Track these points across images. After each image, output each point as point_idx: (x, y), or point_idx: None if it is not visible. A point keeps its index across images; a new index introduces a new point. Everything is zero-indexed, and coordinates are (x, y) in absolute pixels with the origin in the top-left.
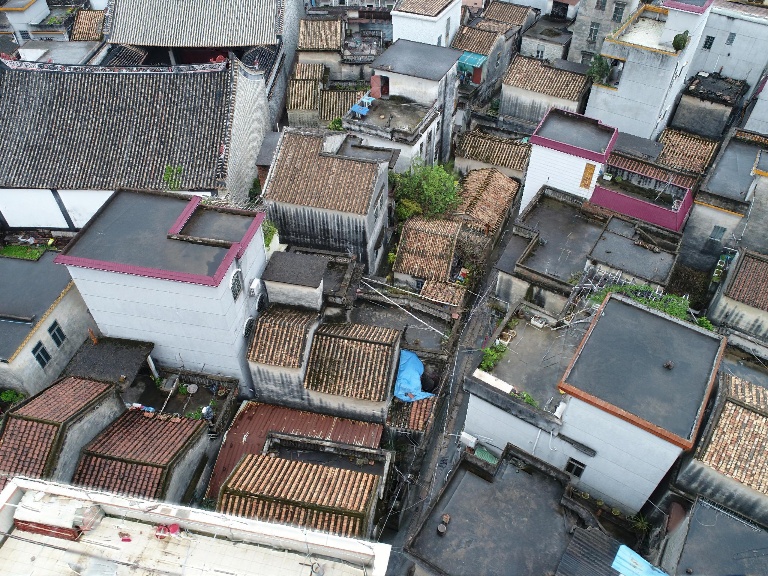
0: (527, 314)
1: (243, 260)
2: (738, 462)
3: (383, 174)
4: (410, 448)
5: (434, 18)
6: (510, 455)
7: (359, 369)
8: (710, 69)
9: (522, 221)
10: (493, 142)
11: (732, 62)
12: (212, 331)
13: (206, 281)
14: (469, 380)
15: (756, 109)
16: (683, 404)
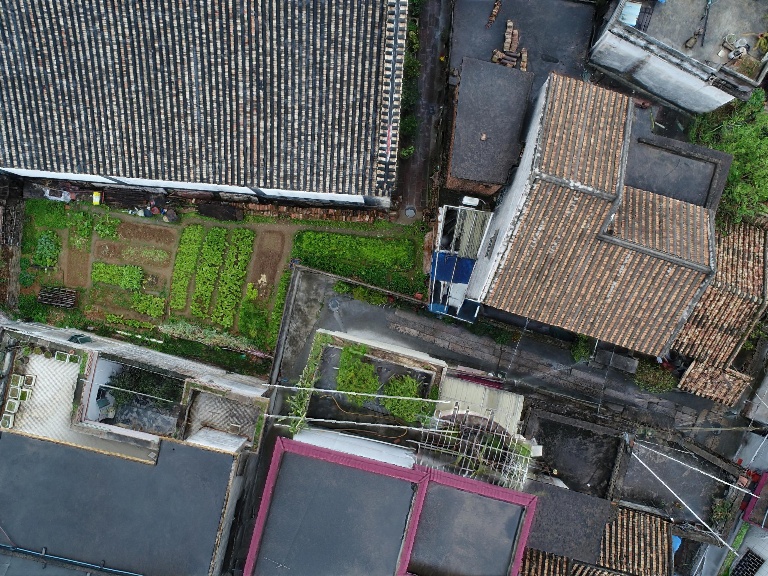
0: None
1: None
2: None
3: None
4: None
5: None
6: None
7: None
8: None
9: None
10: None
11: None
12: None
13: None
14: None
15: None
16: None
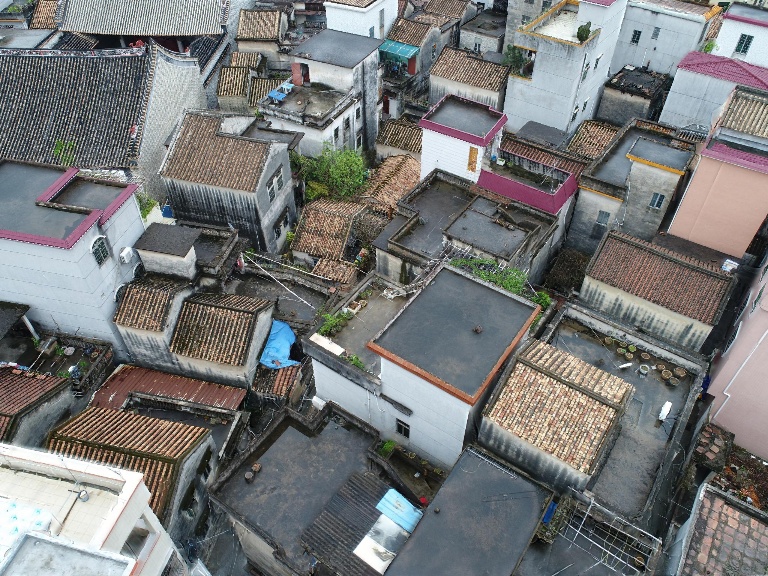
0: (381, 285)
1: (110, 228)
2: (519, 418)
3: (280, 155)
4: (269, 411)
5: (363, 9)
6: (334, 413)
7: (223, 335)
8: (639, 63)
9: (409, 202)
10: (412, 130)
11: (658, 56)
12: (78, 294)
13: (59, 244)
14: (305, 343)
15: (668, 101)
16: (480, 364)
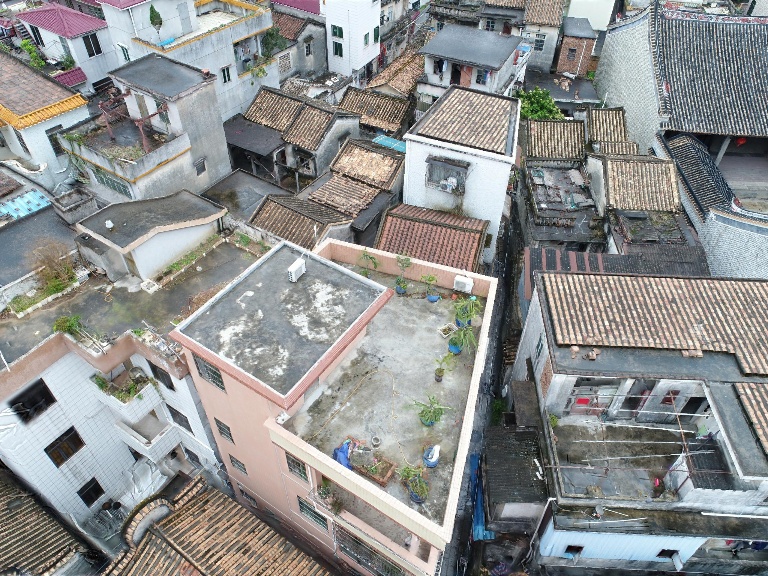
0: None
1: None
2: None
3: None
4: None
5: (455, 85)
6: None
7: None
8: None
9: None
10: None
11: None
12: None
13: None
14: None
15: None
16: None
